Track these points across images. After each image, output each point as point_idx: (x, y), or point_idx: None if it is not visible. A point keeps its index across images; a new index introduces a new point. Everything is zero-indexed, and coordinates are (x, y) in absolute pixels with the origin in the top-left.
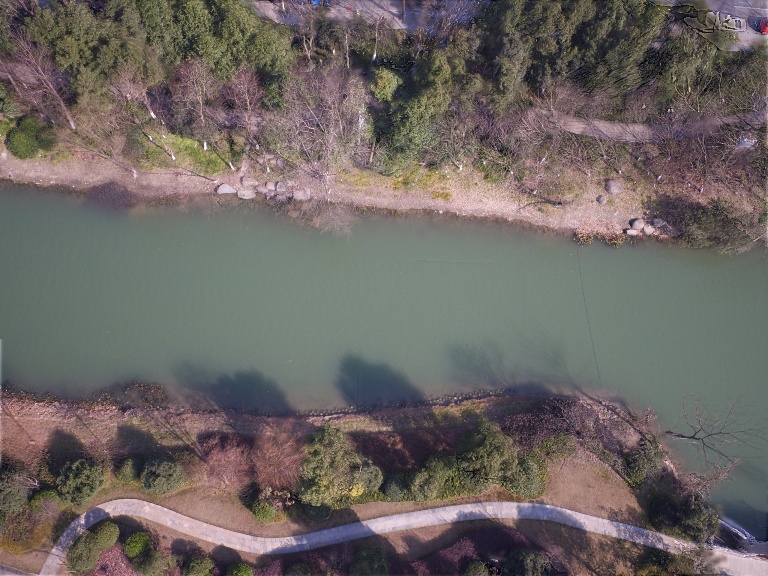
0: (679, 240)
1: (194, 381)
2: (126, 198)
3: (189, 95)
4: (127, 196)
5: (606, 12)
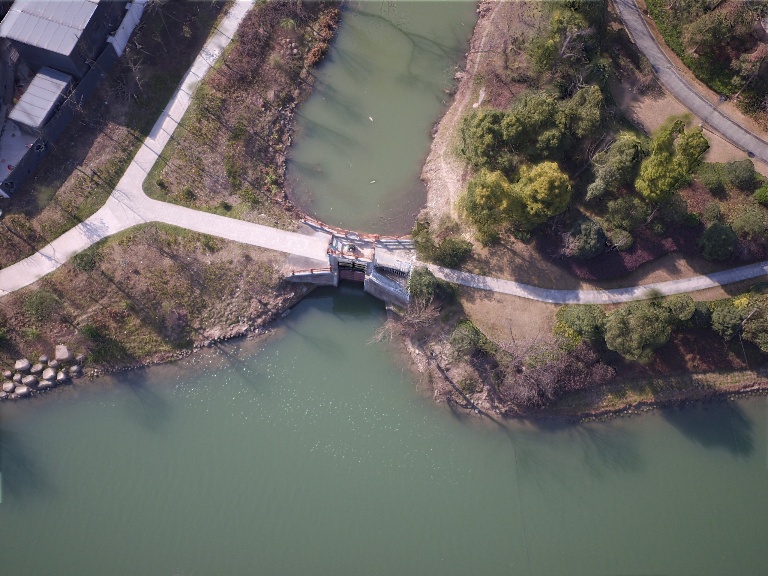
0: None
1: None
2: None
3: None
4: None
5: None
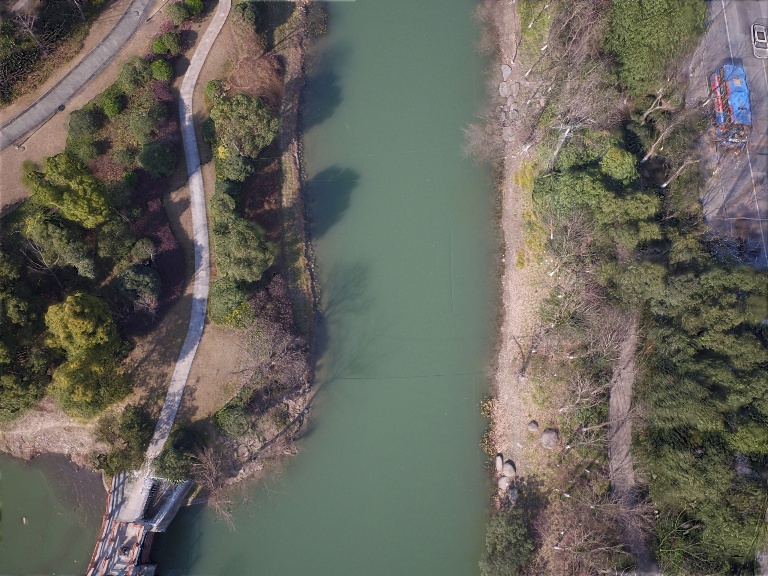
0: (495, 523)
1: (330, 56)
2: (490, 0)
3: (580, 5)
4: (492, 1)
5: (747, 379)
